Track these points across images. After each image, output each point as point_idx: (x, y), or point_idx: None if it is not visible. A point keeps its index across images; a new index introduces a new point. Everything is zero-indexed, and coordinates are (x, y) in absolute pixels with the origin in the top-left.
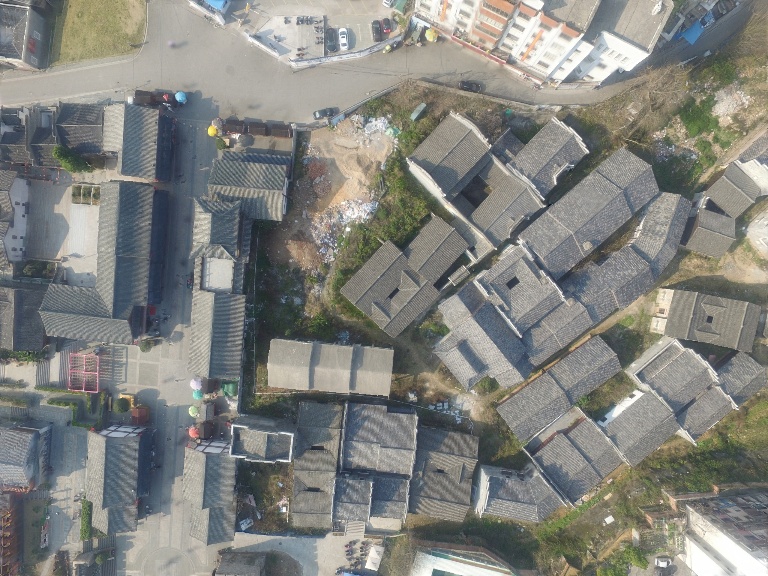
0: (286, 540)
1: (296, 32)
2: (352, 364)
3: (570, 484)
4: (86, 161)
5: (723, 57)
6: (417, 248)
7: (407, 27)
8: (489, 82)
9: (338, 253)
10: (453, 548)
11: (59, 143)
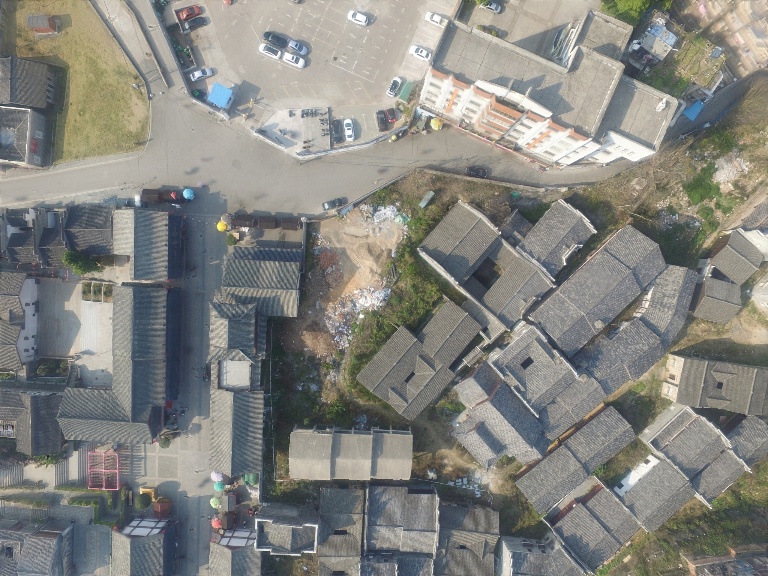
0: None
1: (301, 125)
2: (372, 452)
3: (591, 554)
4: (96, 261)
5: (722, 126)
6: (431, 333)
7: (412, 117)
8: (495, 166)
9: (352, 339)
10: None
11: (68, 247)
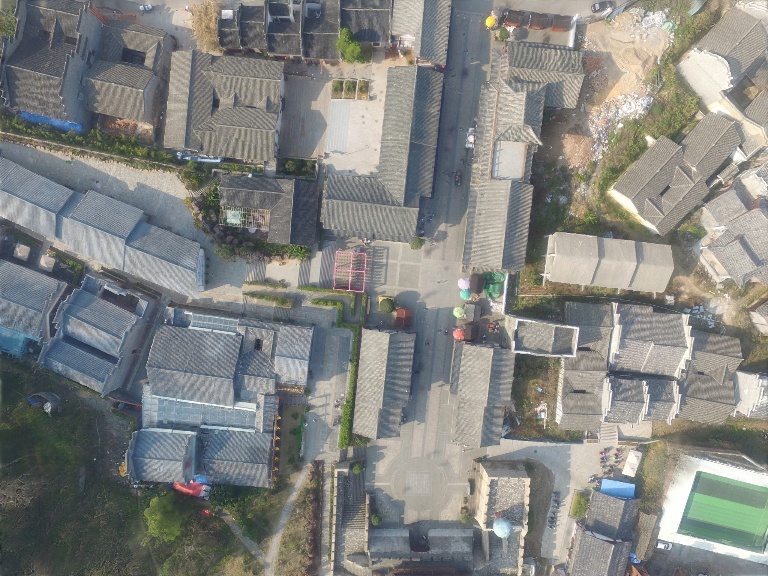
0: (541, 448)
1: None
2: None
3: None
4: None
5: None
6: (693, 143)
7: None
8: None
9: (607, 151)
10: (714, 451)
11: (341, 28)
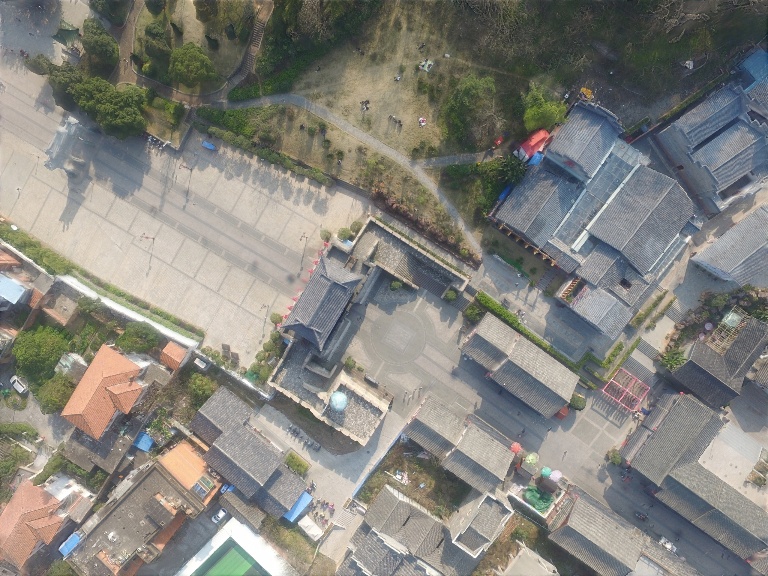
0: (369, 459)
1: None
2: None
3: None
4: None
5: None
6: None
7: None
8: None
9: None
10: None
11: None
